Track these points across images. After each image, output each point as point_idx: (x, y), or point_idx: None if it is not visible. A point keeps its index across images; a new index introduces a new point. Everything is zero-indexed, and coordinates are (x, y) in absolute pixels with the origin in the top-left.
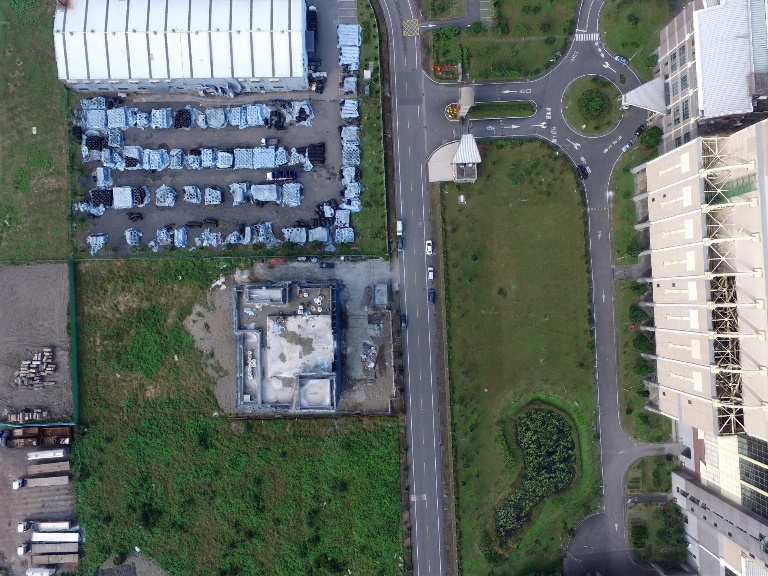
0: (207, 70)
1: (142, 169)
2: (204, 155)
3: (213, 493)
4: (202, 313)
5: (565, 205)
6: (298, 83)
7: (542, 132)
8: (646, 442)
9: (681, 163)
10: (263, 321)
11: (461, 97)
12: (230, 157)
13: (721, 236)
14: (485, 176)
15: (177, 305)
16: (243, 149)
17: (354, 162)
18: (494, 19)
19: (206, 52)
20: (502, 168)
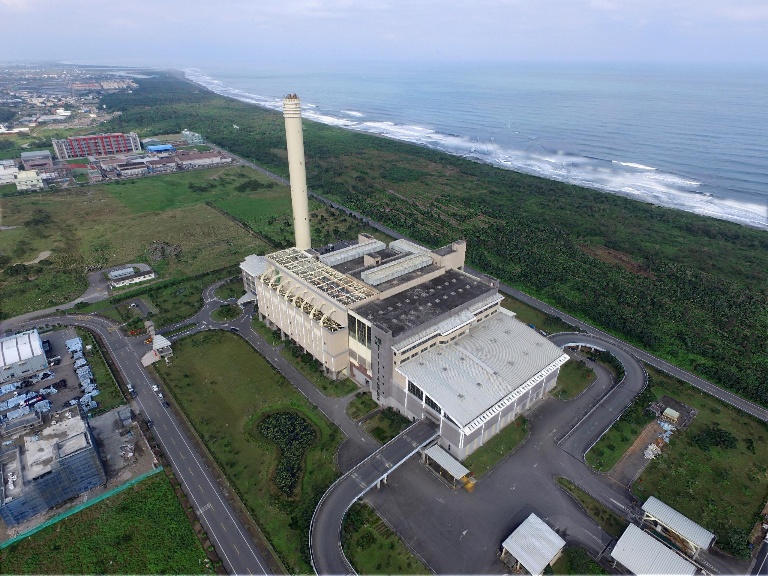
0: None
1: None
2: None
3: None
4: None
5: (232, 342)
6: (40, 362)
7: (204, 328)
8: (346, 395)
9: (259, 291)
10: (21, 442)
11: (145, 325)
12: None
13: None
14: None
15: None
16: None
17: (88, 378)
18: None
19: None
20: (188, 346)
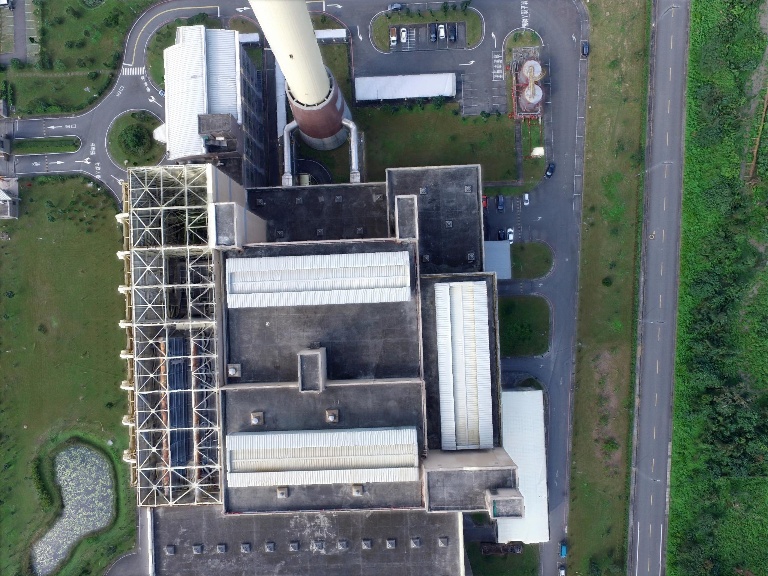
0: None
1: None
2: None
3: None
4: None
5: (107, 241)
6: None
7: (86, 168)
8: None
9: None
10: None
11: None
12: None
13: None
14: None
15: None
16: None
17: None
18: None
19: None
20: None
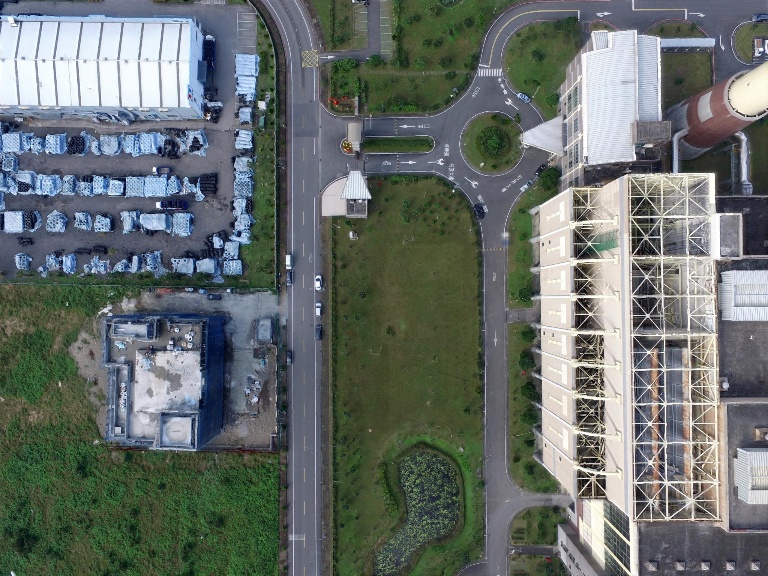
0: (95, 98)
1: (35, 194)
2: (96, 182)
3: (90, 522)
4: (88, 340)
5: (459, 244)
6: (190, 113)
7: (439, 169)
8: (533, 492)
9: (559, 211)
10: (133, 355)
11: (348, 133)
12: (121, 185)
13: (595, 289)
14: (378, 212)
15: (63, 331)
16: (135, 177)
17: (246, 193)
18: (393, 52)
19: (94, 81)
20: (396, 204)
